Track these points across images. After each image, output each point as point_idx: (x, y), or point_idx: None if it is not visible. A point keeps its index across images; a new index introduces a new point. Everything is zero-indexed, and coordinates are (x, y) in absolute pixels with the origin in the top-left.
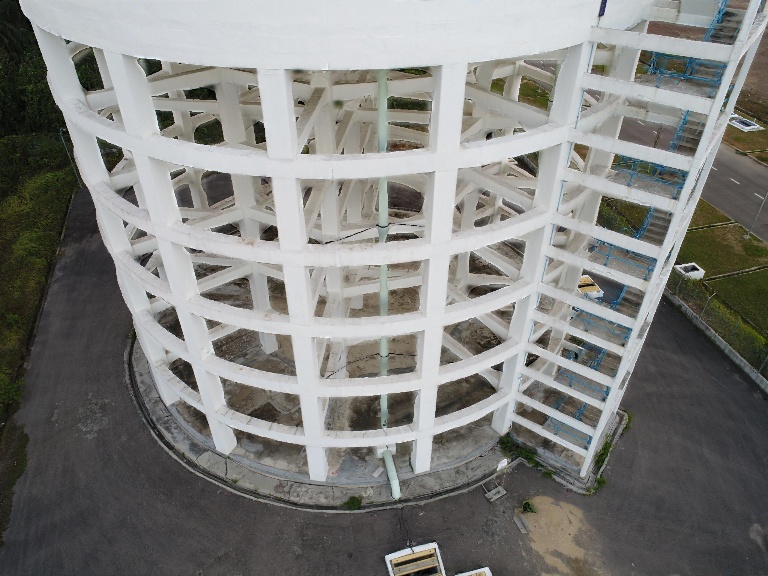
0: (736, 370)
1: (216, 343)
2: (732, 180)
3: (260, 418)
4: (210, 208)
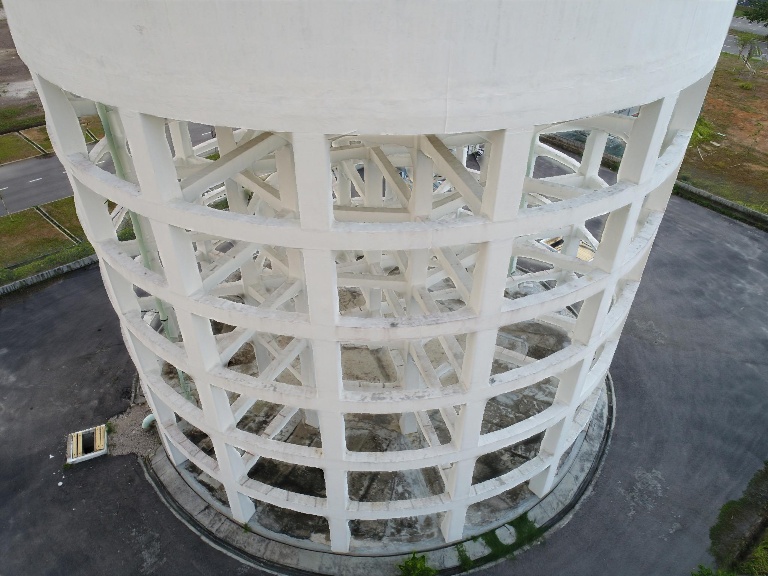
0: None
1: None
2: (34, 181)
3: (544, 355)
4: (318, 502)
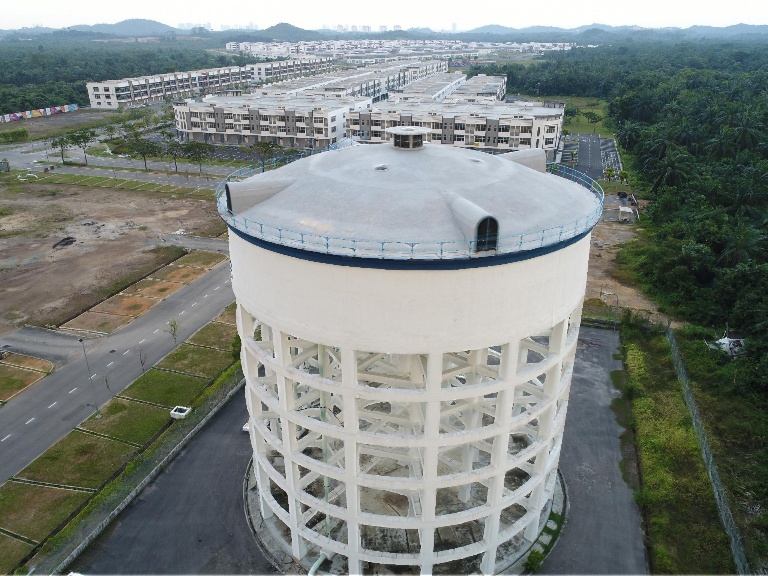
0: (259, 372)
1: (506, 479)
2: None
3: None
4: (482, 543)
